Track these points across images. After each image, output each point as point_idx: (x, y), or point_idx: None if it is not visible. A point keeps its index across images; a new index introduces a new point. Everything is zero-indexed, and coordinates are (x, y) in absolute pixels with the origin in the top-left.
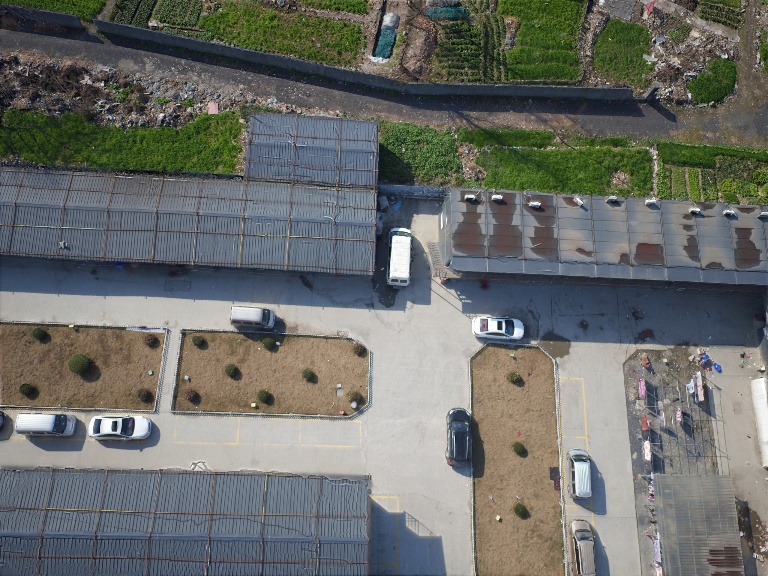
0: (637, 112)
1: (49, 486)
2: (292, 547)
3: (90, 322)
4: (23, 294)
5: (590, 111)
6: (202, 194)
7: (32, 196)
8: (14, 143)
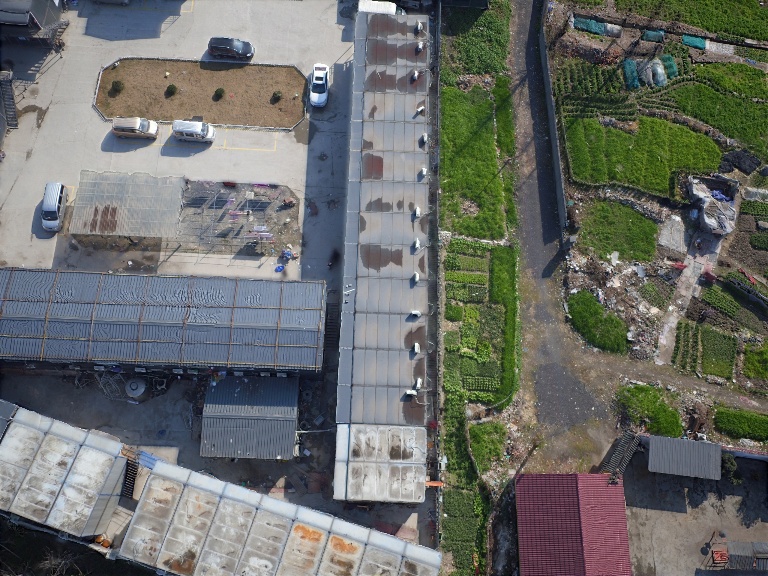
0: (548, 238)
1: None
2: None
3: None
4: None
5: (543, 192)
6: None
7: None
8: None
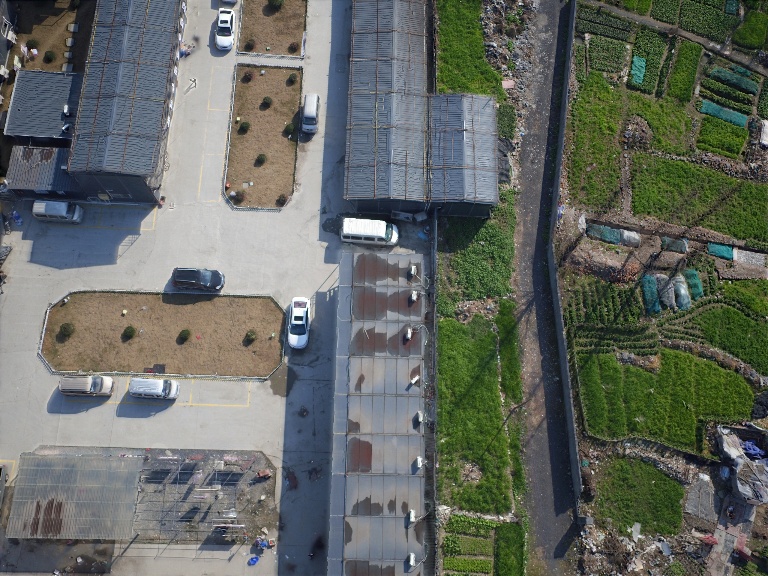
0: (561, 507)
1: None
2: None
3: (310, 8)
4: None
5: (554, 448)
6: None
7: None
8: None
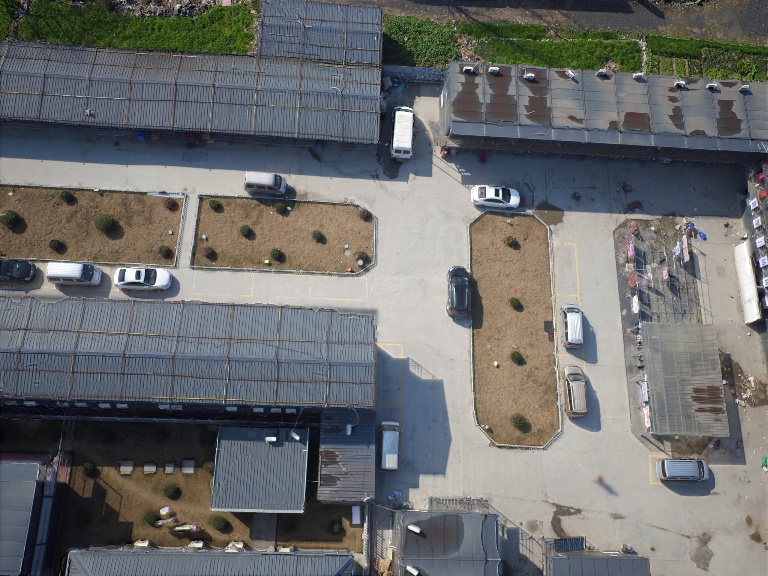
0: (627, 9)
1: (81, 310)
2: (304, 371)
3: (114, 188)
4: (51, 162)
5: (582, 7)
6: (218, 68)
7: (59, 69)
8: (41, 29)
